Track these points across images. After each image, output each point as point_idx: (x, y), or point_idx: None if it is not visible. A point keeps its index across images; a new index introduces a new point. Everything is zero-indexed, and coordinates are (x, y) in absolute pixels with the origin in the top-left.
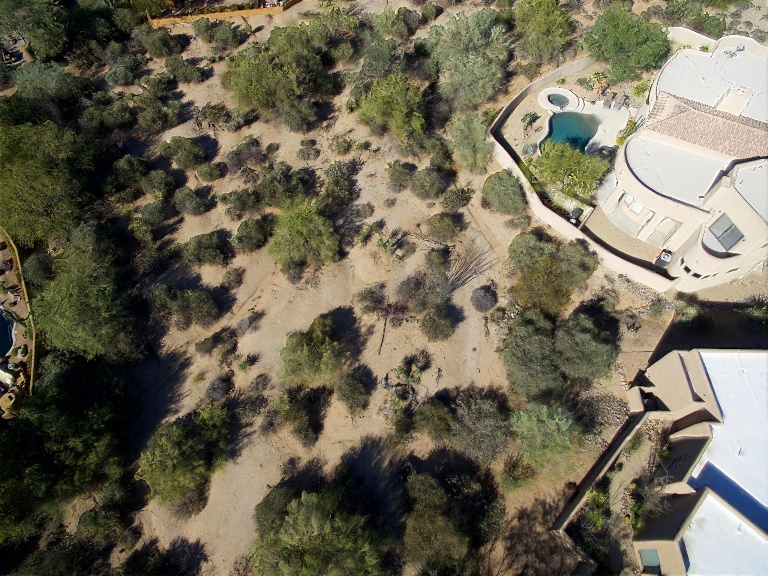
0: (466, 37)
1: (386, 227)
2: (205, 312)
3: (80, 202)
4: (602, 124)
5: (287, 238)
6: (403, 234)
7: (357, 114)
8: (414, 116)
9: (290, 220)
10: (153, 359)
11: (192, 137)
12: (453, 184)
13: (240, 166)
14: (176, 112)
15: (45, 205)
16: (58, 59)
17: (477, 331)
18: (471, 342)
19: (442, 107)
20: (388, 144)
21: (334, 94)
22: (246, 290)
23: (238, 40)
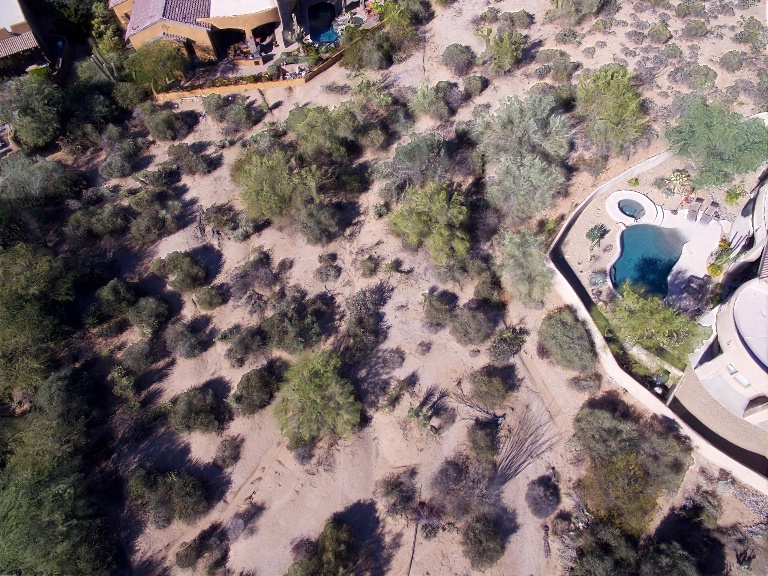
0: (519, 129)
1: (419, 384)
2: (190, 509)
3: (56, 337)
4: (687, 244)
5: (296, 403)
6: (440, 395)
7: (386, 220)
8: (456, 237)
9: (301, 379)
10: (124, 567)
11: (192, 247)
12: (502, 321)
13: (246, 289)
14: (176, 213)
15: (10, 352)
16: (49, 145)
17: (534, 548)
18: (527, 566)
19: (489, 218)
20: (423, 263)
21: (360, 191)
22: (244, 468)
23: (252, 121)
